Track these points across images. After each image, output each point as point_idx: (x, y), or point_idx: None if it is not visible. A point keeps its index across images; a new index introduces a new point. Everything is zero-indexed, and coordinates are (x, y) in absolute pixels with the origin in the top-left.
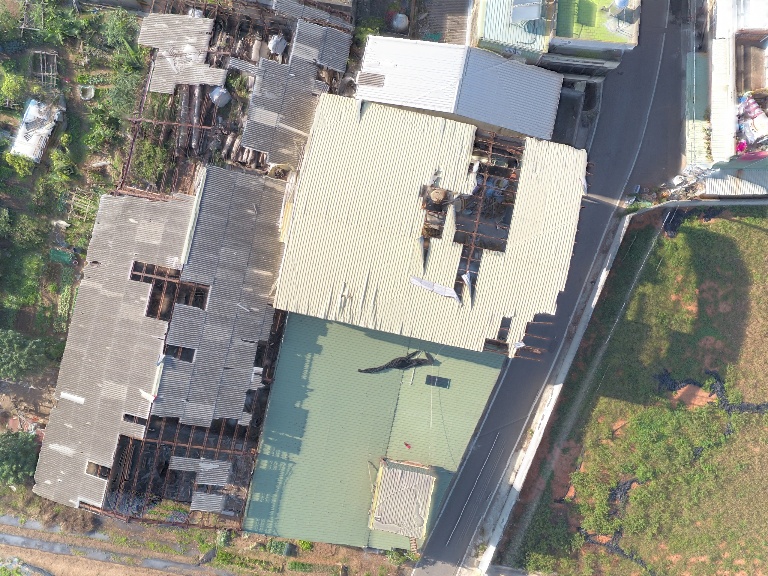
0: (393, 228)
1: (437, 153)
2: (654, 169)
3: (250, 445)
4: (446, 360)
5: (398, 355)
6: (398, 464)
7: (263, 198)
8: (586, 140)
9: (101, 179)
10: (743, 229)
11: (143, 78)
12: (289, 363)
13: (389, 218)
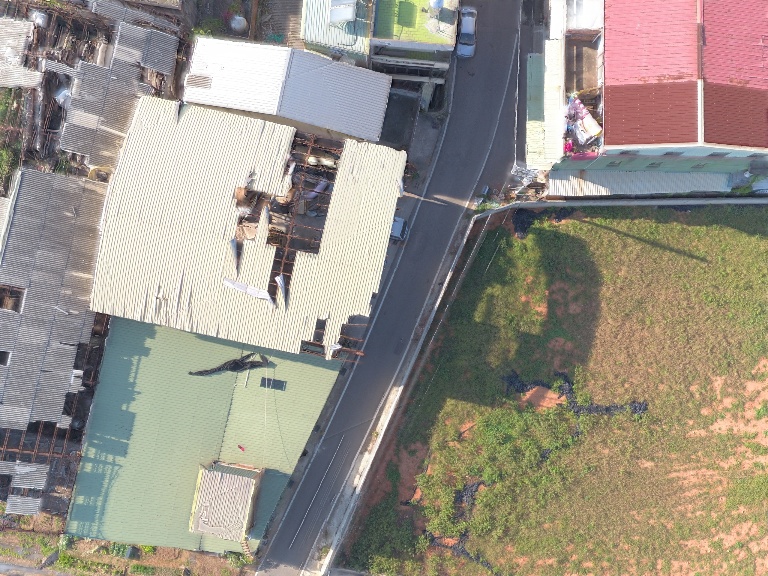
0: (206, 230)
1: (253, 155)
2: (504, 170)
3: (72, 448)
4: (282, 362)
5: (231, 357)
6: (227, 467)
7: (83, 201)
8: (436, 142)
9: None
10: (593, 230)
11: None
12: (115, 366)
13: (202, 220)
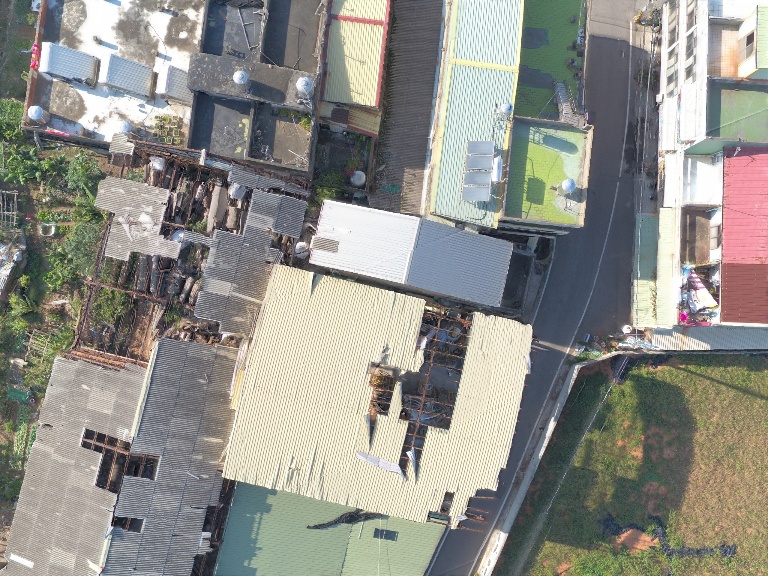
0: (341, 404)
1: (386, 329)
2: (604, 317)
3: None
4: None
5: (347, 510)
6: None
7: (215, 367)
8: (539, 287)
9: (59, 318)
10: (688, 377)
11: (101, 229)
12: (238, 523)
13: (337, 394)
